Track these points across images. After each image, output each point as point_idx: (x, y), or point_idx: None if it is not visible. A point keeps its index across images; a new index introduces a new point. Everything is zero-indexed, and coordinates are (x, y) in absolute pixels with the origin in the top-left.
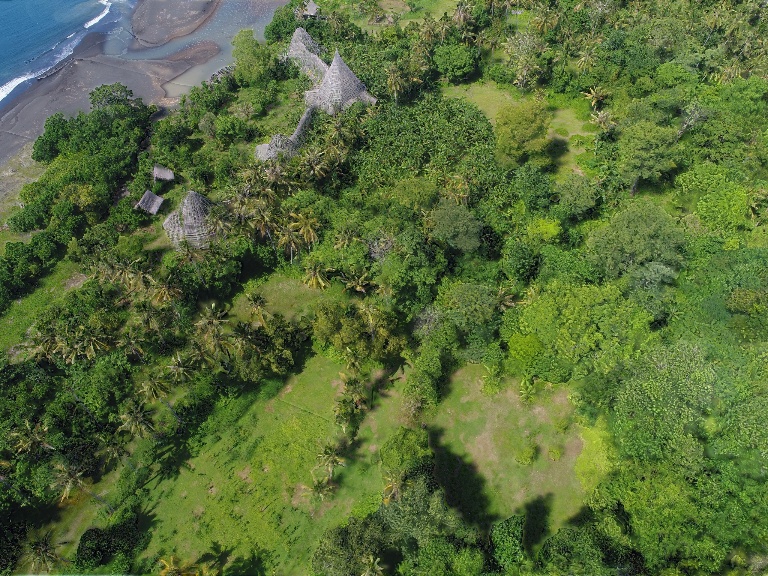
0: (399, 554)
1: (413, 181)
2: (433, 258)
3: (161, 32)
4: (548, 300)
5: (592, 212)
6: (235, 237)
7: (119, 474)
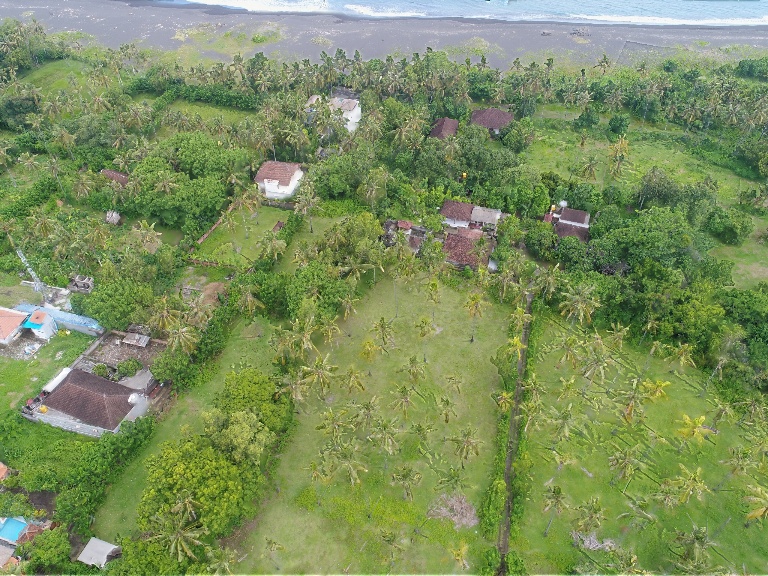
0: None
1: None
2: None
3: None
4: None
5: None
6: None
7: None
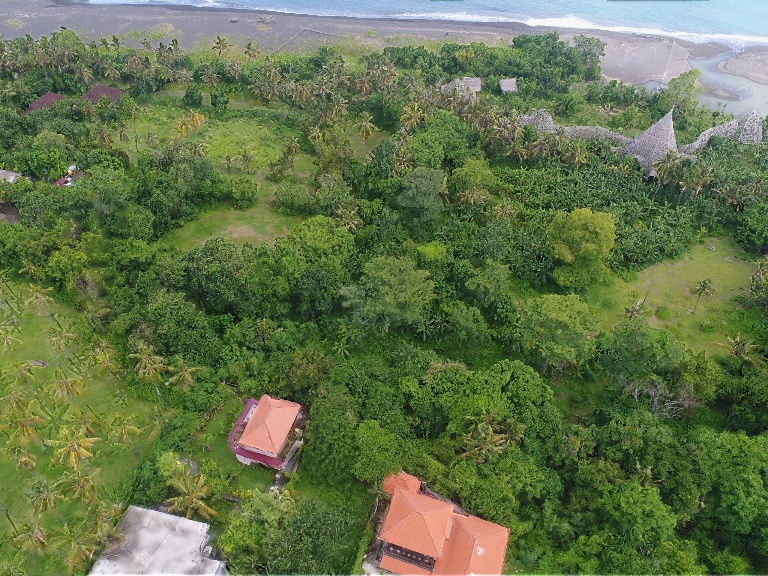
0: None
1: (483, 170)
2: (386, 179)
3: (748, 68)
4: (323, 220)
5: (499, 324)
6: None
7: None
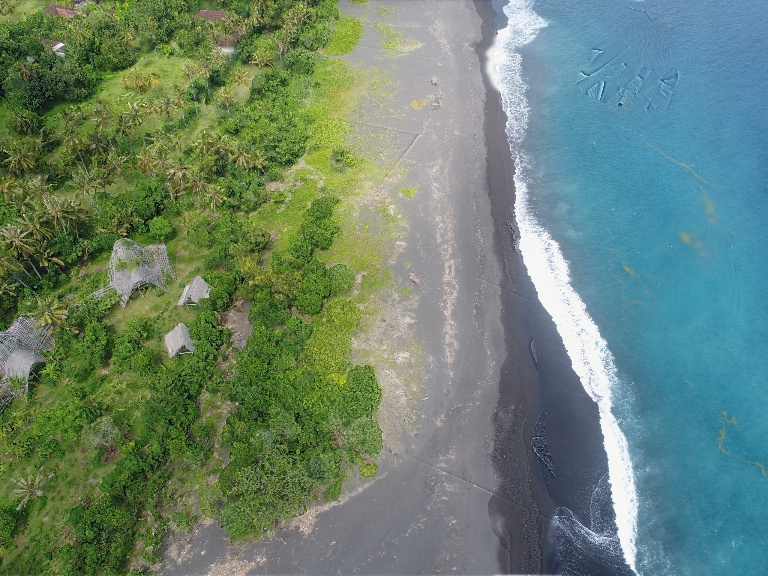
0: (50, 102)
1: None
2: None
3: None
4: None
5: None
6: None
7: (198, 128)
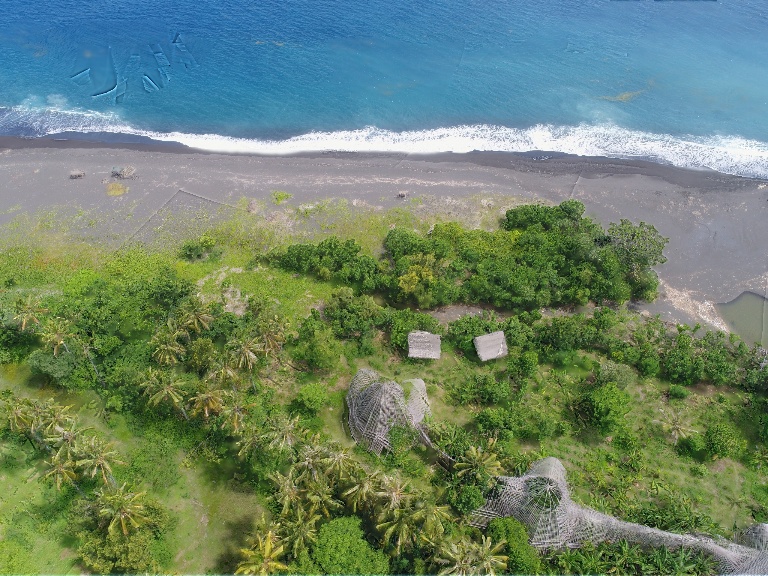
0: None
1: None
2: None
3: None
4: None
5: None
6: (373, 463)
7: None
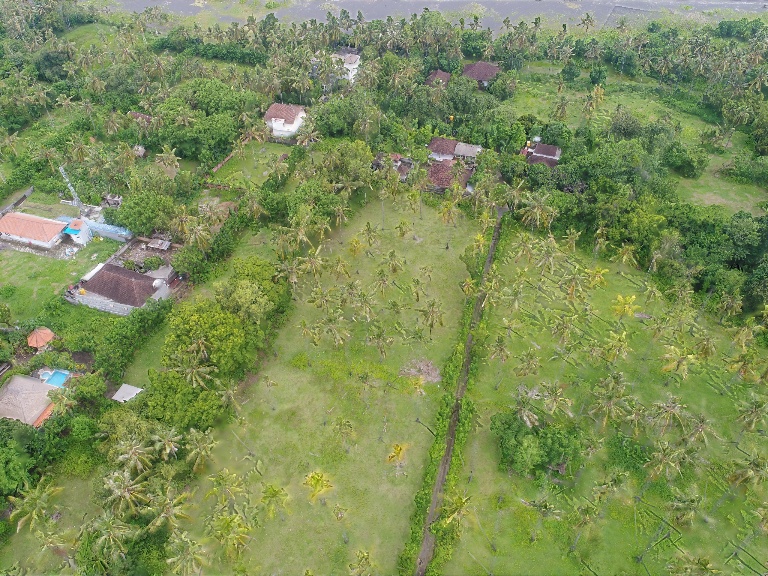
0: None
1: None
2: None
3: None
4: None
5: None
6: None
7: None
